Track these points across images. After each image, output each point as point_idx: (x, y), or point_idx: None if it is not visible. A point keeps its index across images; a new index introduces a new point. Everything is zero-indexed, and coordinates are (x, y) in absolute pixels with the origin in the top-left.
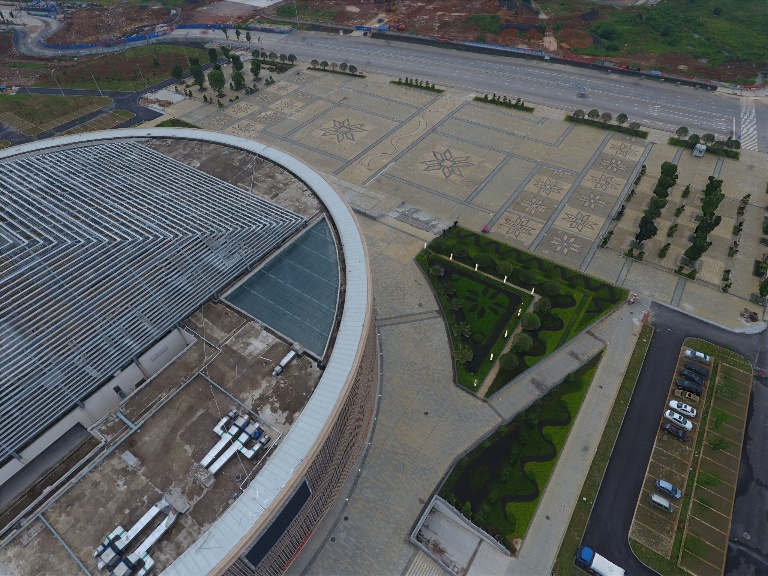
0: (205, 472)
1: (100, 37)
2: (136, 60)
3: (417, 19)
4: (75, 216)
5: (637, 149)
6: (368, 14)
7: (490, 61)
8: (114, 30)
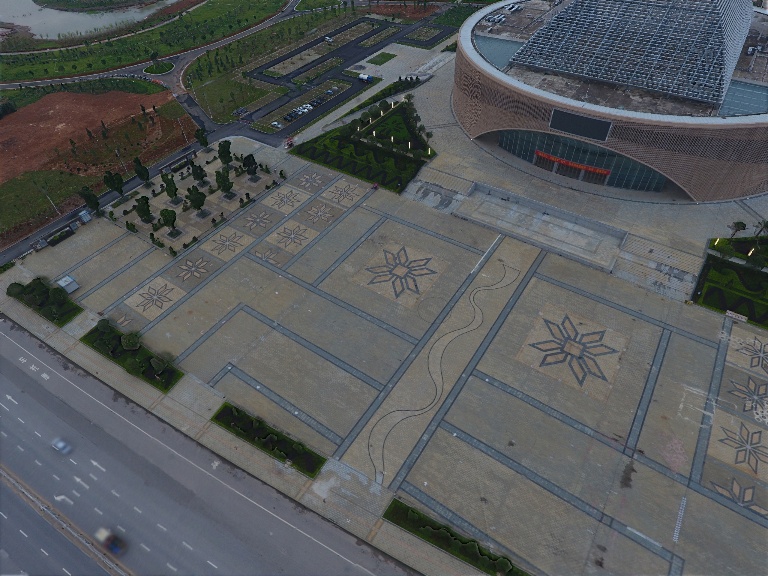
0: (501, 13)
1: None
2: None
3: None
4: (616, 1)
5: (136, 299)
6: None
7: None
8: None
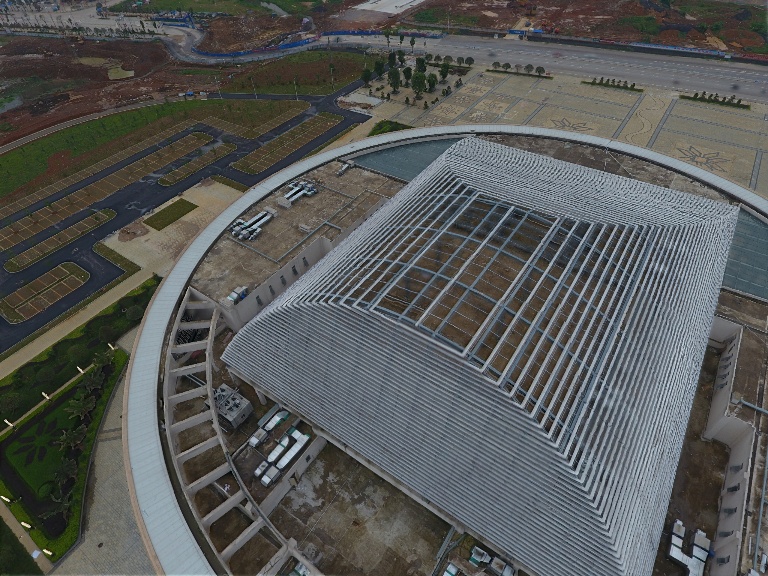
0: None
1: (244, 45)
2: (306, 65)
3: (563, 22)
4: None
5: None
6: (510, 18)
7: (668, 61)
8: (252, 38)
